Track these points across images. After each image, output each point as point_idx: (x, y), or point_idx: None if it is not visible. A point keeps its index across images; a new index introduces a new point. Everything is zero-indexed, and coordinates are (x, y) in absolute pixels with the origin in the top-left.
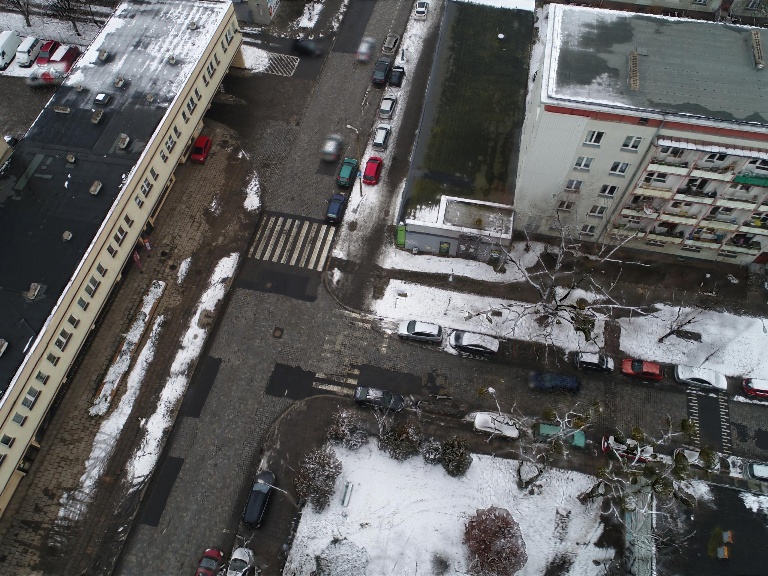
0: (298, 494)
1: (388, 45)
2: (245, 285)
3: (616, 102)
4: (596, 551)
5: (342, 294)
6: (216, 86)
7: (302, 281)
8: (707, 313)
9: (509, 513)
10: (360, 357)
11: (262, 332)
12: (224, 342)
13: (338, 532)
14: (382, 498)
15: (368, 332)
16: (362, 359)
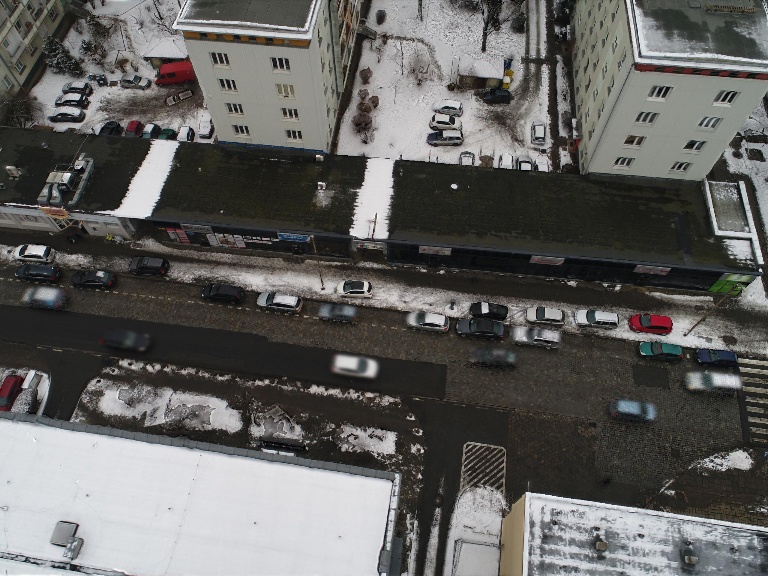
0: None
1: (442, 320)
2: None
3: (767, 26)
4: None
5: None
6: None
7: None
8: None
9: None
10: None
11: None
12: None
13: None
14: None
15: None
16: None
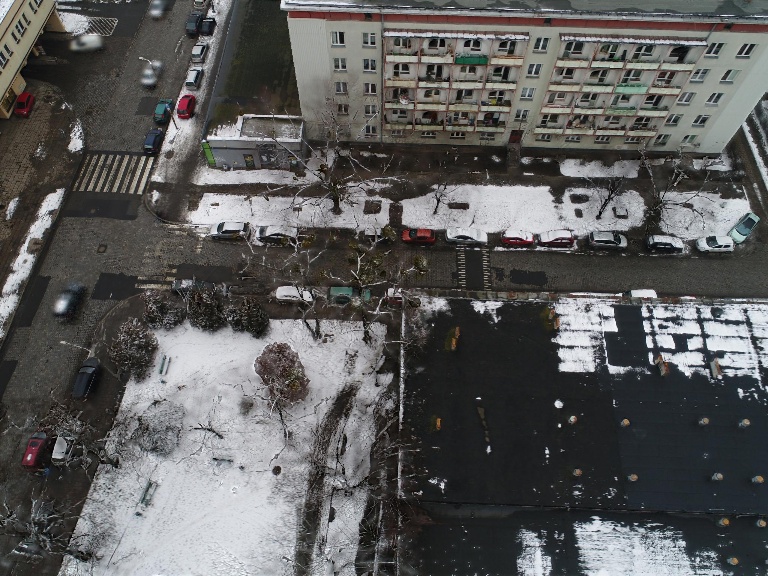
0: (123, 373)
1: None
2: (71, 214)
3: (341, 2)
4: (378, 377)
5: (160, 210)
6: (30, 45)
7: (123, 204)
8: (474, 187)
9: (287, 345)
10: (177, 259)
11: (87, 250)
12: (52, 263)
13: (158, 396)
14: (197, 364)
15: (184, 238)
16: (179, 260)
